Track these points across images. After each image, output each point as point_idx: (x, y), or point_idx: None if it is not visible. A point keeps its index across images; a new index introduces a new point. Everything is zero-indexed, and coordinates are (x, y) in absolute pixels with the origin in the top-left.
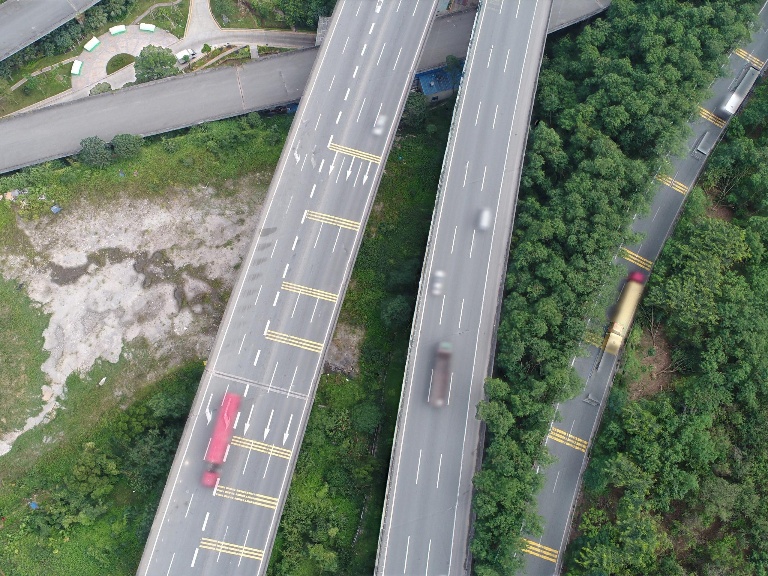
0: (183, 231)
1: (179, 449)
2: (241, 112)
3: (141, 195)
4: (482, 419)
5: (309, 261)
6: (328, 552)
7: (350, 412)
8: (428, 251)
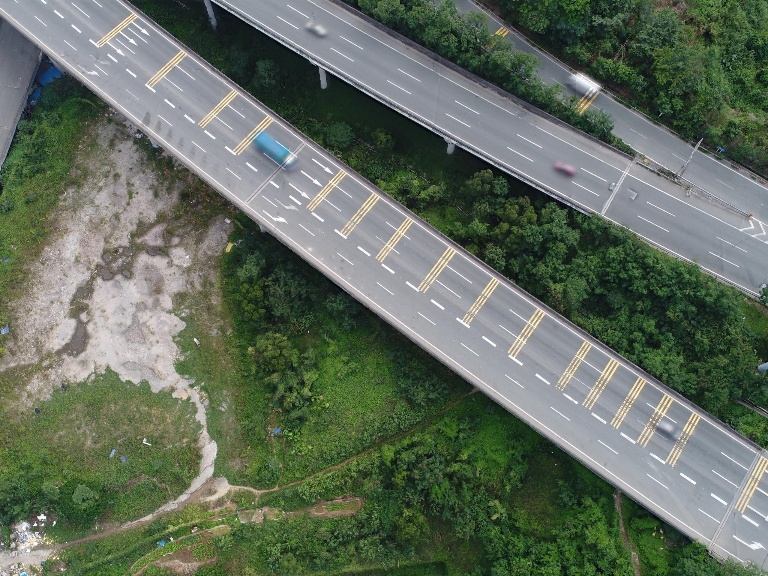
0: (96, 227)
1: (296, 250)
2: (12, 132)
3: (39, 250)
4: (387, 17)
5: (192, 99)
6: (430, 188)
7: (330, 147)
8: (235, 11)
